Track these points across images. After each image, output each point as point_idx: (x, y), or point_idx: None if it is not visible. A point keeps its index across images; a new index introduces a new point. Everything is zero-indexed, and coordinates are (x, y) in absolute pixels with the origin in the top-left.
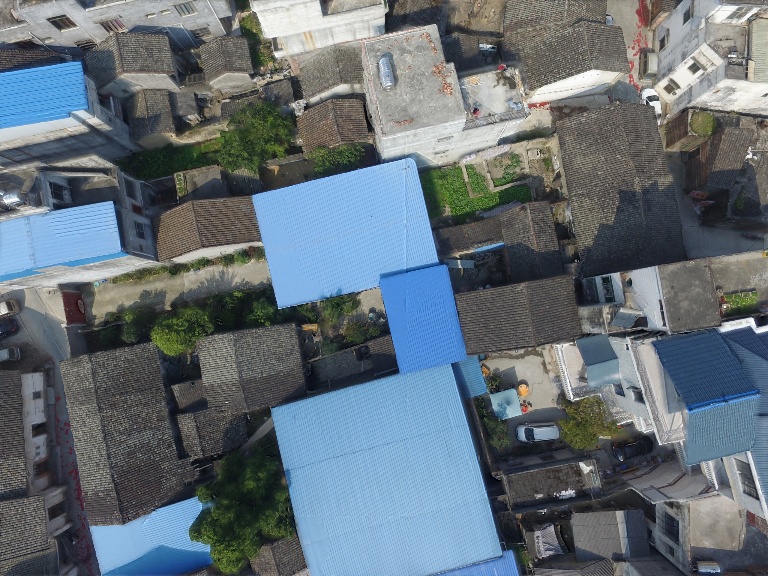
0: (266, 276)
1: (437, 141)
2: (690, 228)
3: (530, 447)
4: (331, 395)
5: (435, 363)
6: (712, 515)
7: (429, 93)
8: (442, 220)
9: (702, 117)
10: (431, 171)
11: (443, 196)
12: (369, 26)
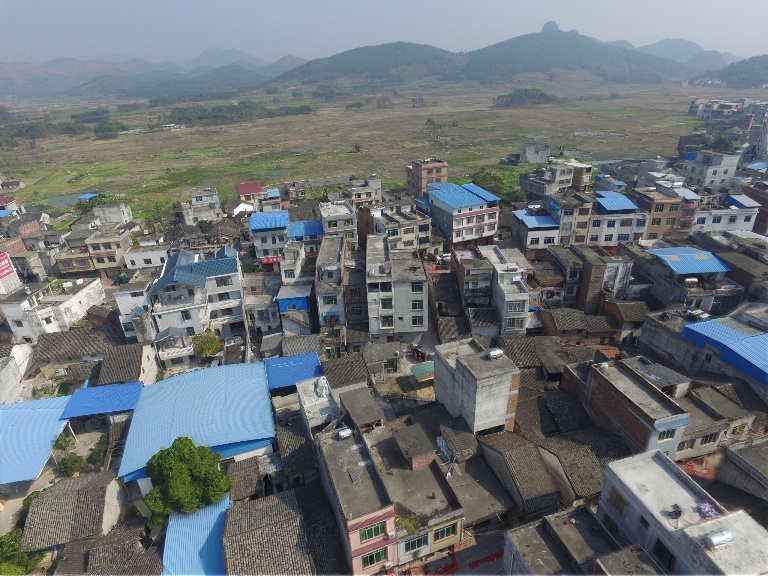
0: (8, 525)
1: None
2: None
3: None
4: (128, 442)
5: (138, 394)
6: (255, 302)
7: None
8: None
9: None
10: None
11: None
12: None
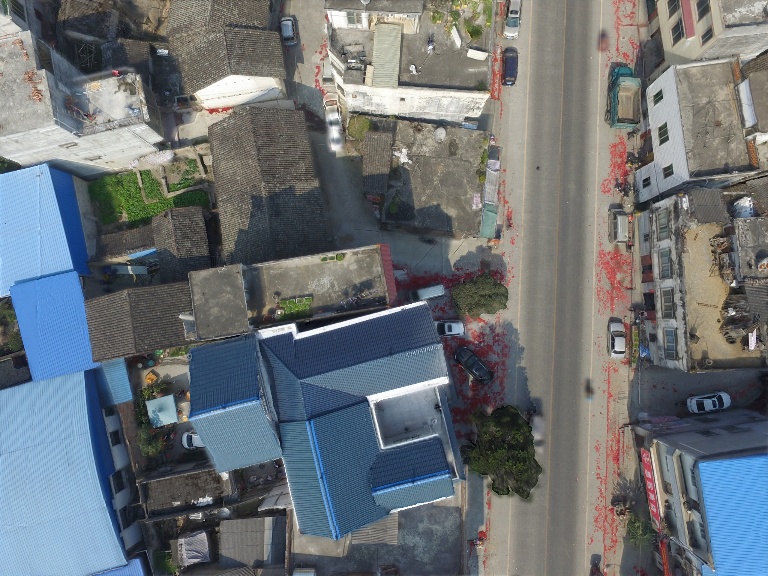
0: None
1: (65, 147)
2: (370, 232)
3: (193, 454)
4: None
5: (68, 371)
6: None
7: (19, 100)
8: (118, 226)
9: (359, 122)
10: (105, 177)
11: (119, 202)
12: (6, 32)
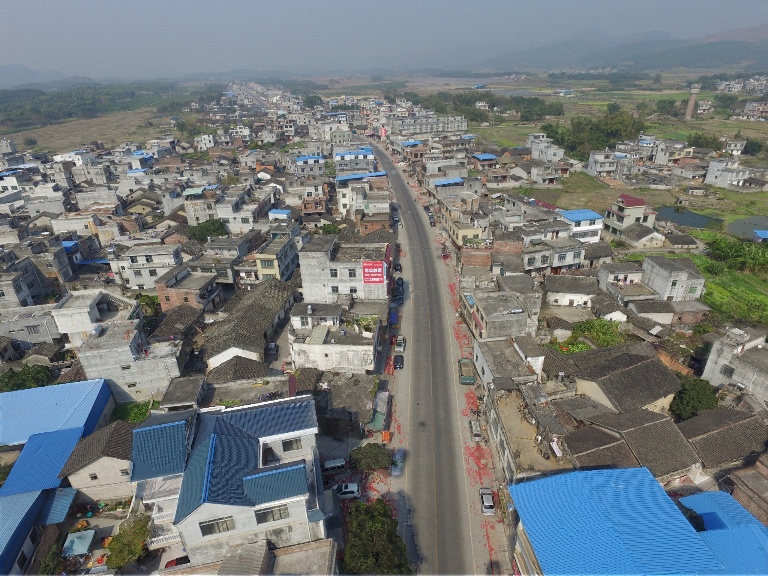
0: None
1: (122, 369)
2: None
3: None
4: None
5: (30, 490)
6: None
7: None
8: None
9: None
10: (129, 403)
11: (130, 416)
12: None
